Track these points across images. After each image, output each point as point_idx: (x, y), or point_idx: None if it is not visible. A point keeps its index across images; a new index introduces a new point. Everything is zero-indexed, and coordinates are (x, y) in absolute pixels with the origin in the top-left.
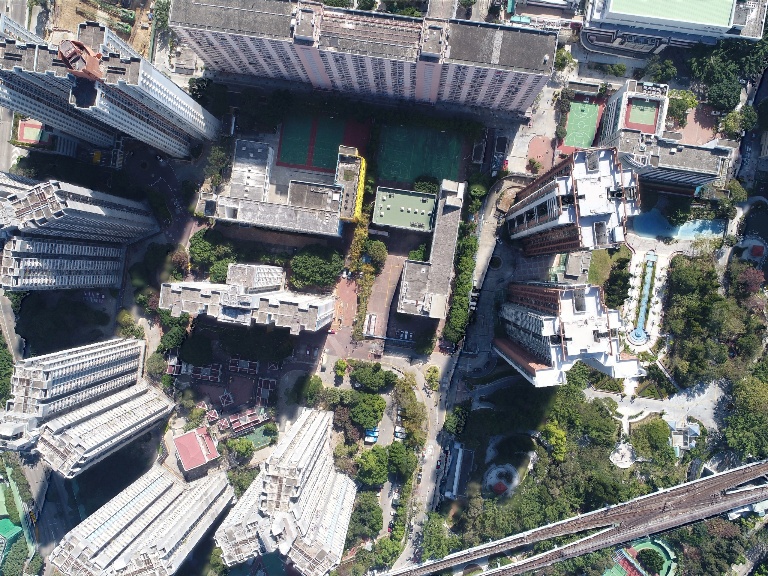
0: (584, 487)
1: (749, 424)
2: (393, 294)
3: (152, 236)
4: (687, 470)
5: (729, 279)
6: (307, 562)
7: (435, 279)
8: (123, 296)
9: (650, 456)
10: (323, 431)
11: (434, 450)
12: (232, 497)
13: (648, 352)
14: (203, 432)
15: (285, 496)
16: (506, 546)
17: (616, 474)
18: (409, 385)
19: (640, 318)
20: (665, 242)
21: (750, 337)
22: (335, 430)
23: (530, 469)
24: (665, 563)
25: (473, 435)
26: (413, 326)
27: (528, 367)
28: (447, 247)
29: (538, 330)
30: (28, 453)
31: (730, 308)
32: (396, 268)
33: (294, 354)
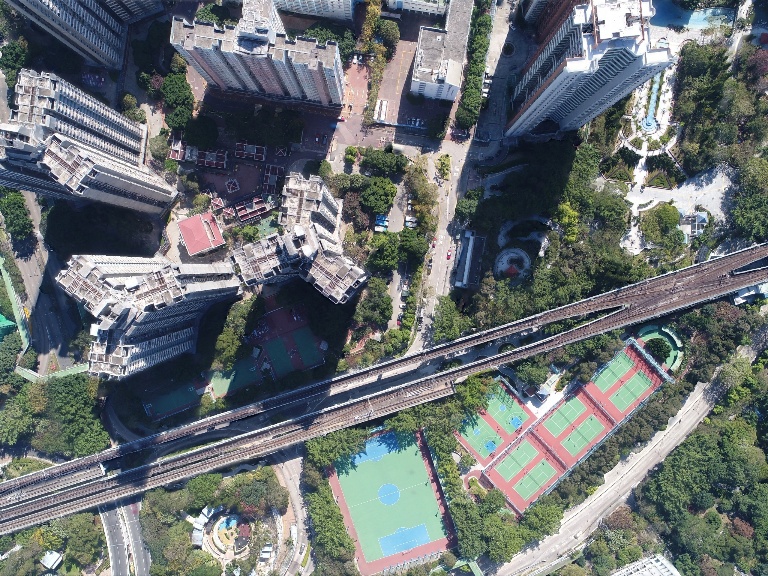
0: (595, 269)
1: (757, 203)
2: (404, 81)
3: (155, 17)
4: (694, 259)
5: (738, 67)
6: (328, 280)
7: (451, 47)
8: (124, 80)
9: (660, 240)
10: (335, 202)
11: (444, 240)
12: (237, 288)
13: (658, 141)
14: (208, 217)
15: (306, 211)
16: (517, 329)
17: (626, 257)
18: (421, 165)
19: (651, 106)
20: (676, 30)
21: (758, 119)
22: (344, 221)
23: (541, 256)
24: (671, 353)
25: (486, 216)
26: (424, 114)
27: (556, 72)
28: (463, 14)
29: (568, 26)
30: (34, 165)
31: (739, 91)
32: (408, 54)
33: (302, 142)
